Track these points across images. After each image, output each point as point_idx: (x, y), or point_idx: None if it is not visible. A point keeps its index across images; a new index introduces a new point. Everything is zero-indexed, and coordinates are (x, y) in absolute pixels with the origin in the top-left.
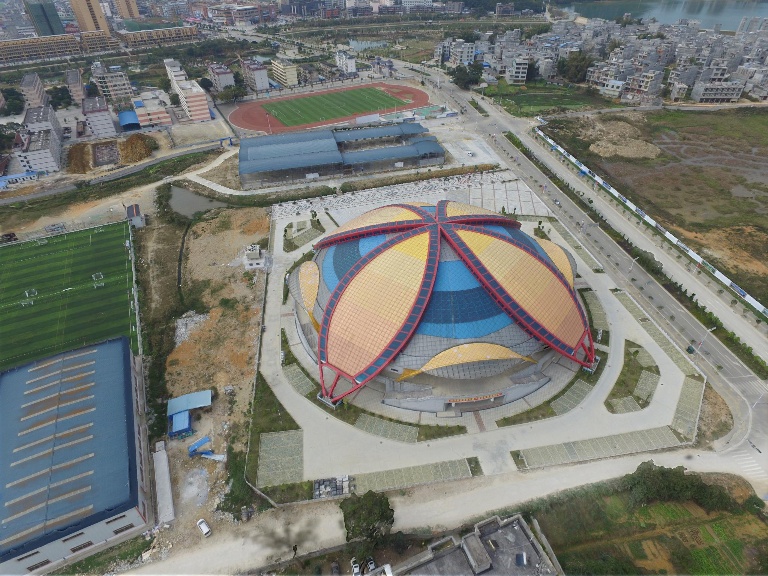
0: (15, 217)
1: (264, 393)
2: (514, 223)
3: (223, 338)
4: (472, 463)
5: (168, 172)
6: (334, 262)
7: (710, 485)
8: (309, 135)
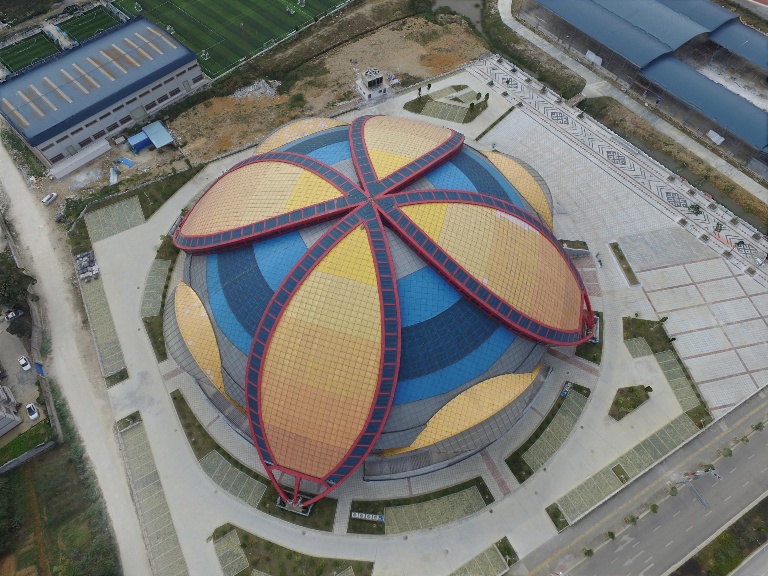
0: None
1: (176, 177)
2: (502, 319)
3: (247, 120)
4: (120, 374)
5: None
6: (312, 138)
7: None
8: (692, 3)
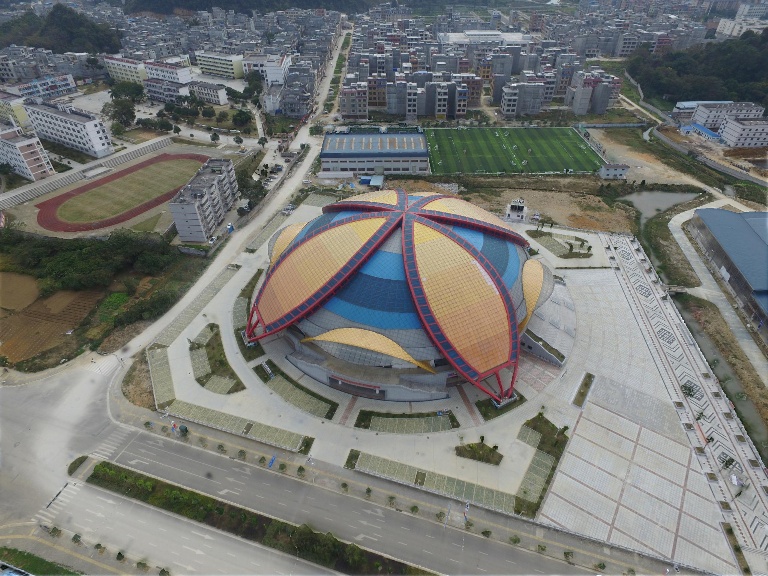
0: (630, 138)
1: None
2: None
3: None
4: None
5: (739, 192)
6: None
7: (125, 317)
8: None
